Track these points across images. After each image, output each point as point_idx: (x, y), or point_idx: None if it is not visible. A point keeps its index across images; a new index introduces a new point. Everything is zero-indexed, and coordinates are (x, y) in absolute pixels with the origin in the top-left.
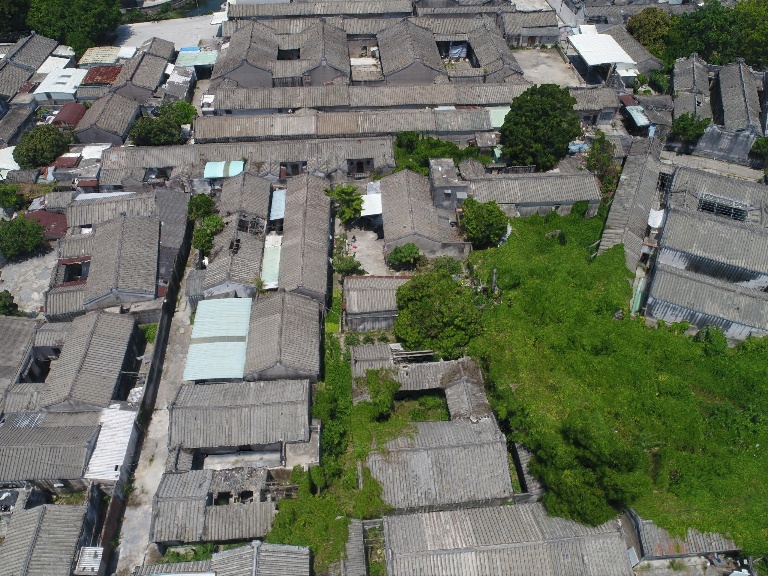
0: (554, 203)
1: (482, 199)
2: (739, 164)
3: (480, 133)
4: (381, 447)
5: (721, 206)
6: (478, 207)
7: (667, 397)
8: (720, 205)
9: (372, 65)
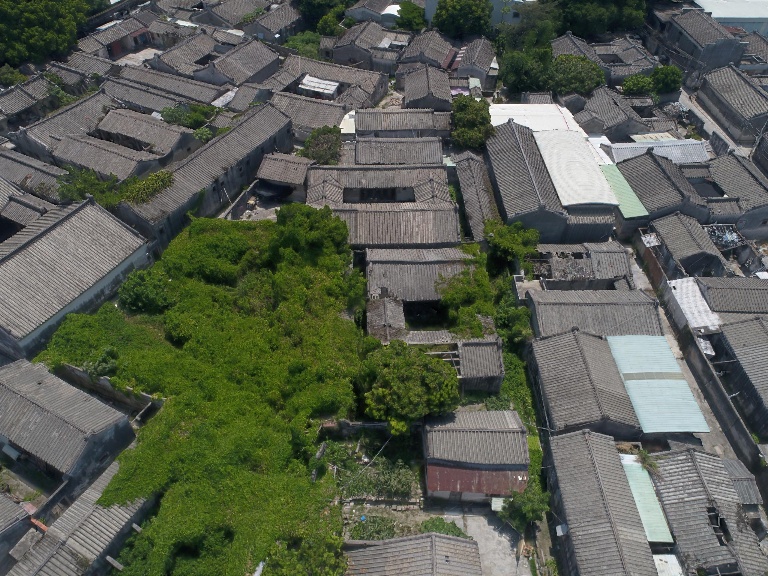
0: None
1: None
2: None
3: None
4: (466, 267)
5: None
6: None
7: None
8: None
9: None
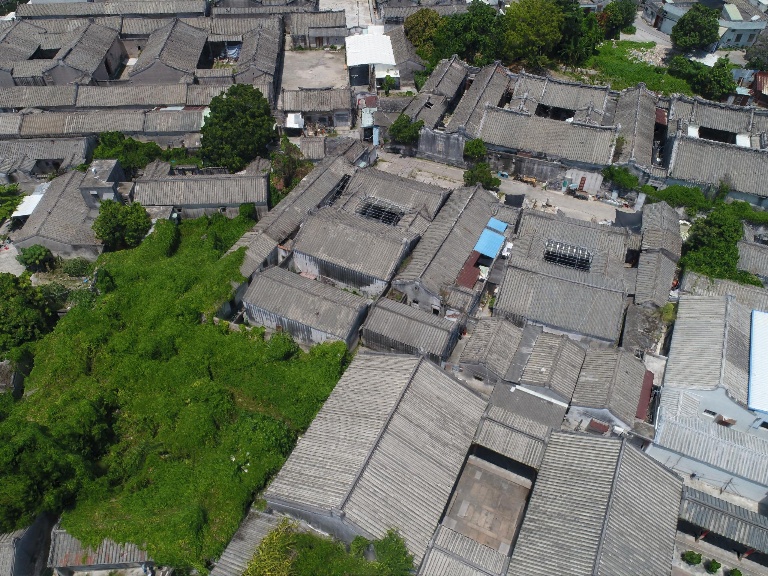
0: (218, 205)
1: (143, 200)
2: (458, 167)
3: (190, 134)
4: None
5: (374, 209)
6: (114, 208)
7: (196, 403)
8: (374, 208)
9: None
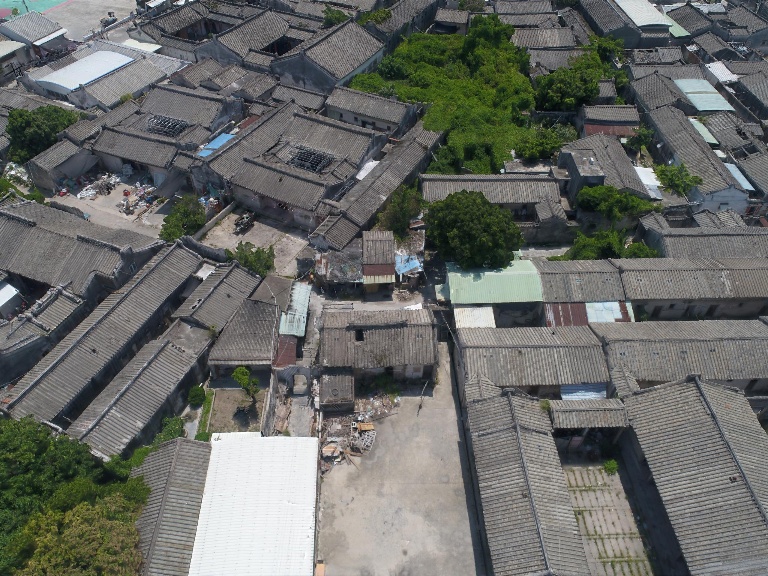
0: None
1: None
2: None
3: None
4: None
5: (314, 152)
6: (547, 141)
7: None
8: (314, 153)
9: None
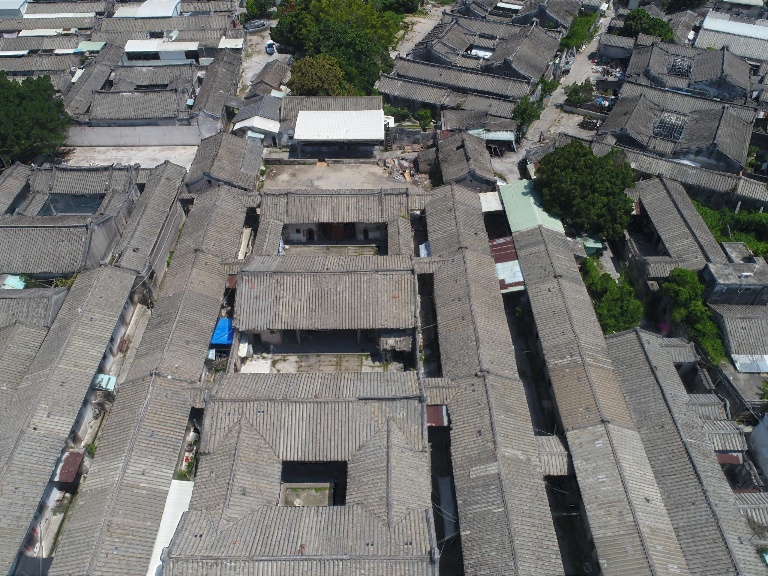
0: None
1: None
2: None
3: None
4: None
5: (675, 126)
6: None
7: None
8: (674, 126)
9: (272, 367)
